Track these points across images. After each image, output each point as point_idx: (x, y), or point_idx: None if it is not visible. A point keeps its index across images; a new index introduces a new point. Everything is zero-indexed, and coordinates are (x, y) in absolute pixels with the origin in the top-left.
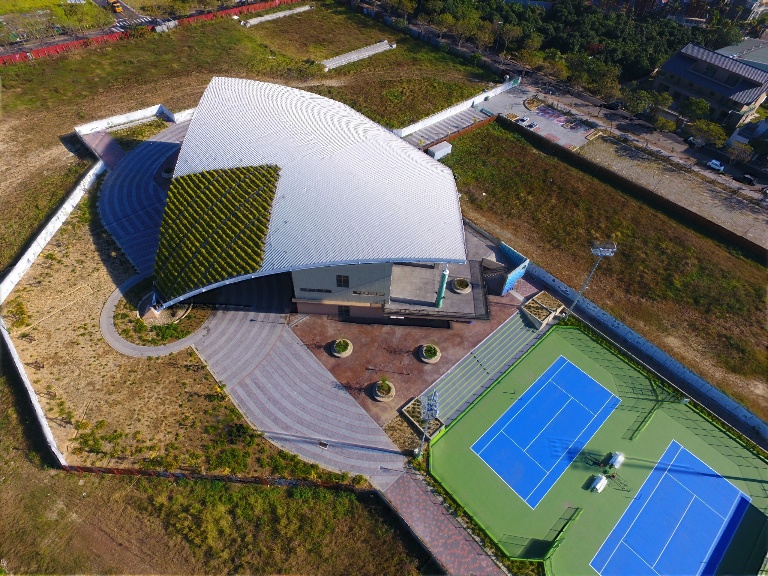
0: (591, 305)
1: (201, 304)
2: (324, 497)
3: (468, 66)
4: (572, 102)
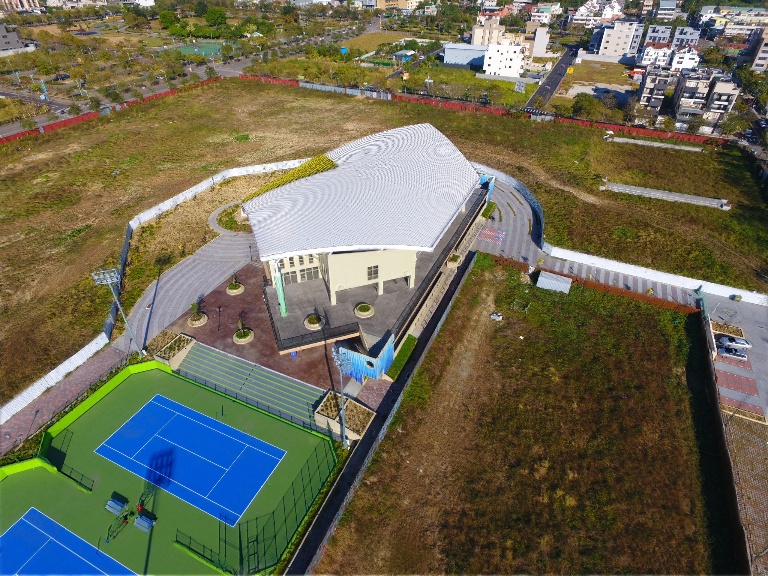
0: None
1: None
2: None
3: None
4: None
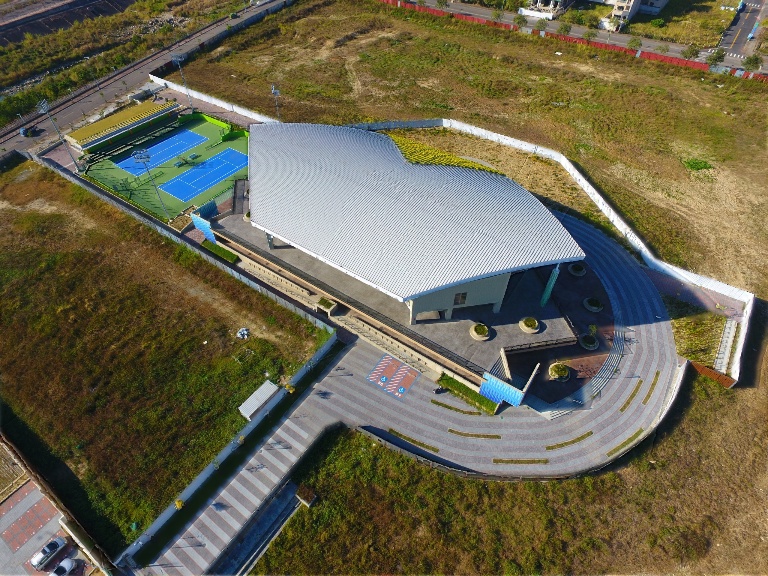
0: None
1: None
2: None
3: None
4: None
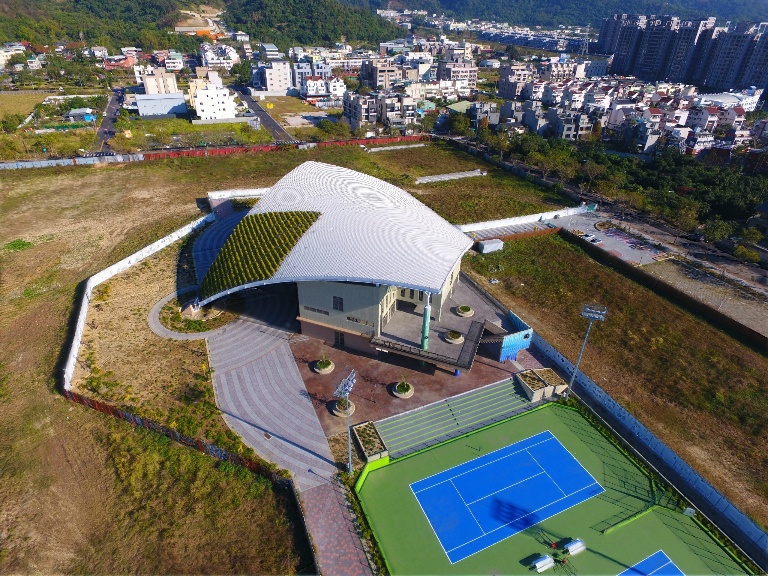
0: (597, 389)
1: (229, 313)
2: (244, 476)
3: (548, 193)
4: (649, 230)
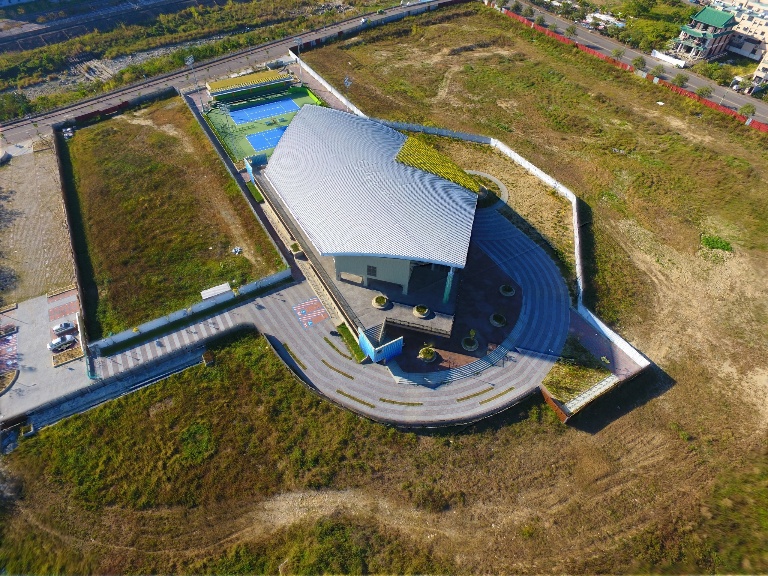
0: None
1: None
2: None
3: None
4: None
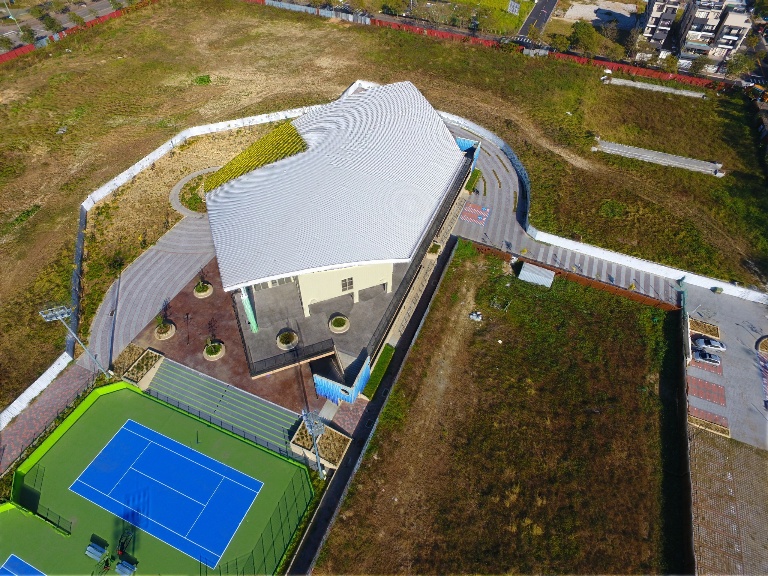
0: None
1: None
2: None
3: None
4: None
